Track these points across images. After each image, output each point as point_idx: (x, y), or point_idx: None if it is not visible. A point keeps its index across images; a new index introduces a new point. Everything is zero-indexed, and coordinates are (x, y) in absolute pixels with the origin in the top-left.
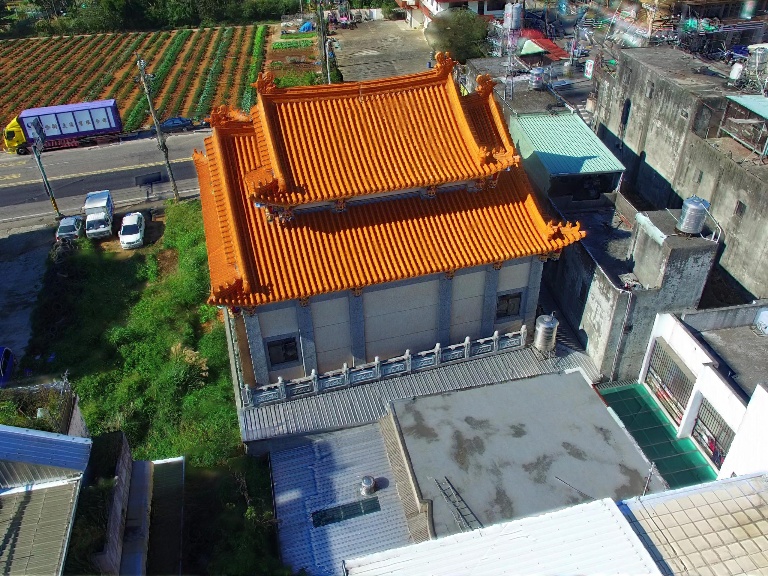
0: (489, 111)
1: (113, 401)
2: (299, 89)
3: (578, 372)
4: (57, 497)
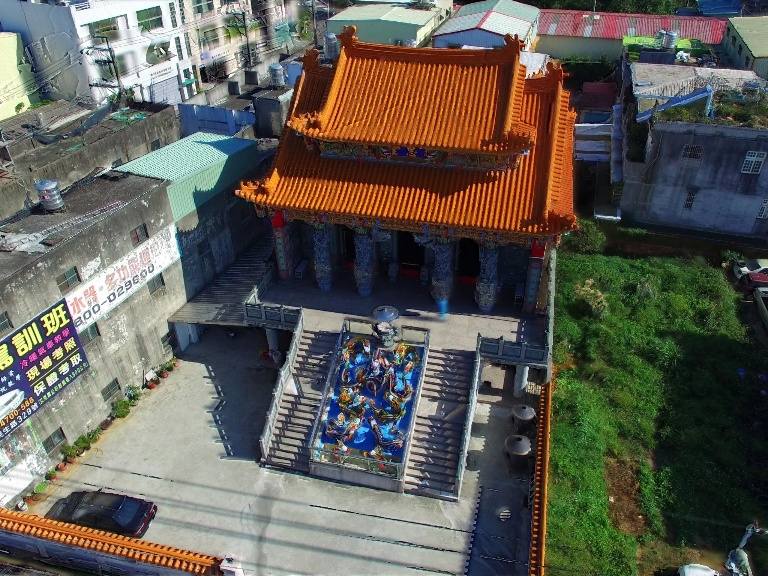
0: None
1: (658, 305)
2: (483, 51)
3: None
4: None
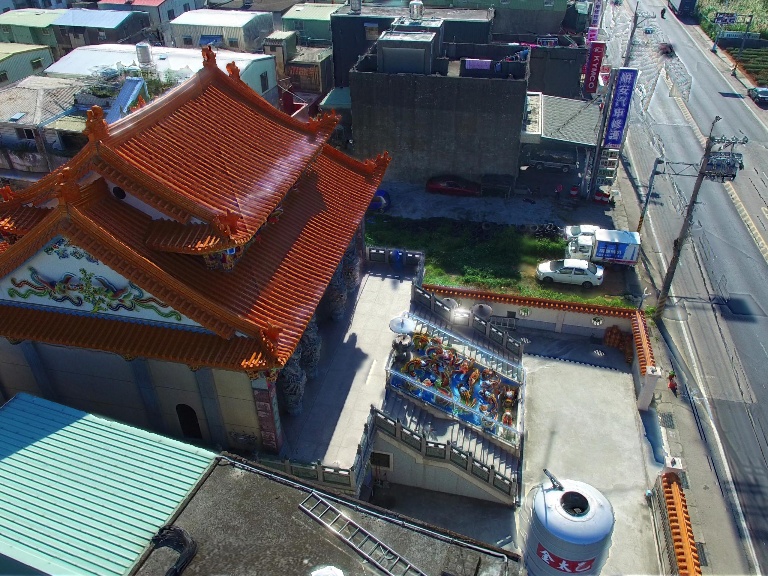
0: None
1: None
2: None
3: None
4: None
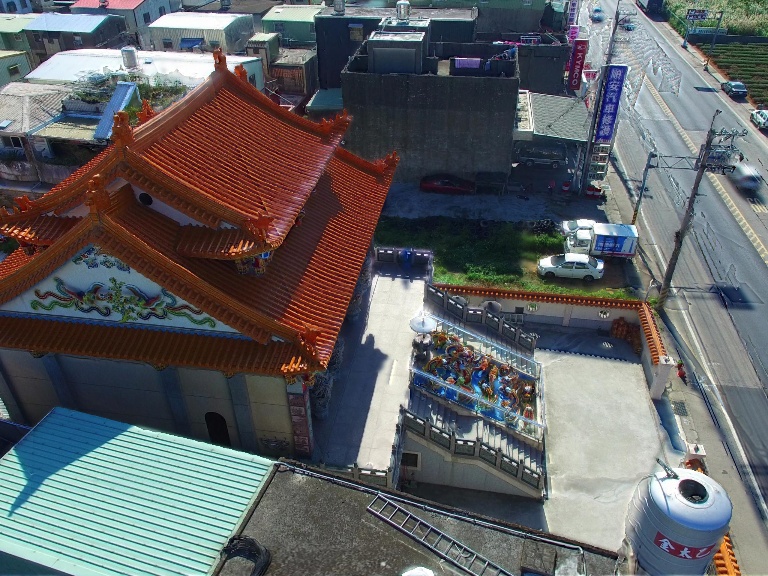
0: None
1: None
2: None
3: None
4: (92, 135)
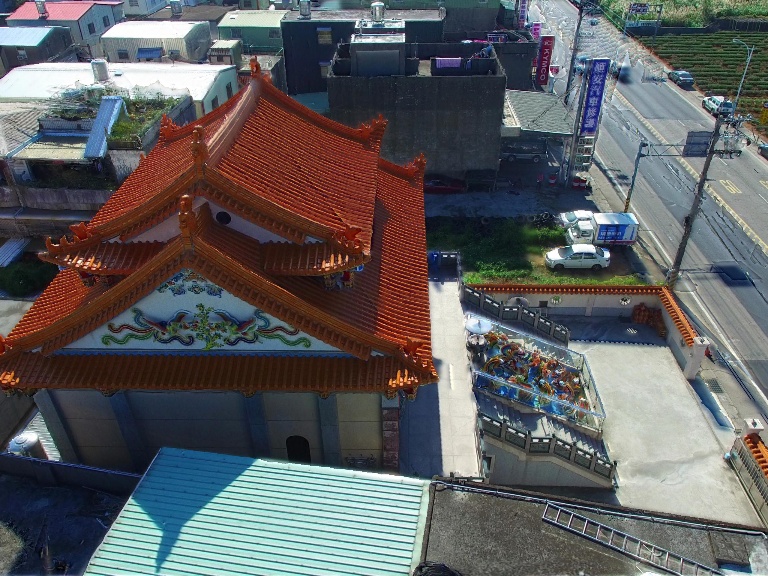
0: None
1: None
2: None
3: None
4: (80, 154)
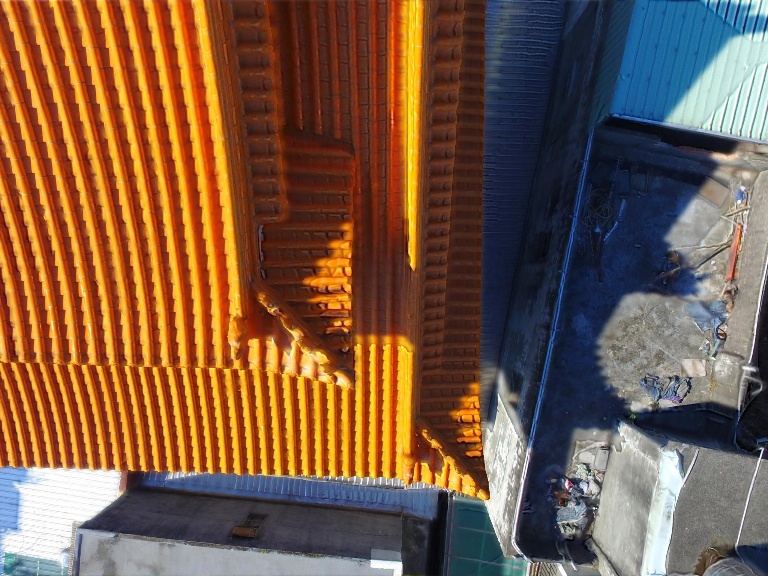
0: (401, 18)
1: None
2: None
3: (390, 571)
4: None
